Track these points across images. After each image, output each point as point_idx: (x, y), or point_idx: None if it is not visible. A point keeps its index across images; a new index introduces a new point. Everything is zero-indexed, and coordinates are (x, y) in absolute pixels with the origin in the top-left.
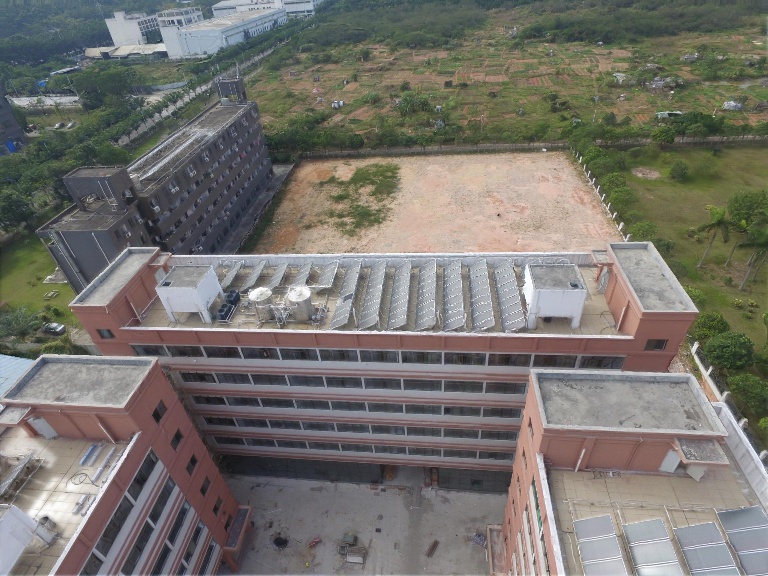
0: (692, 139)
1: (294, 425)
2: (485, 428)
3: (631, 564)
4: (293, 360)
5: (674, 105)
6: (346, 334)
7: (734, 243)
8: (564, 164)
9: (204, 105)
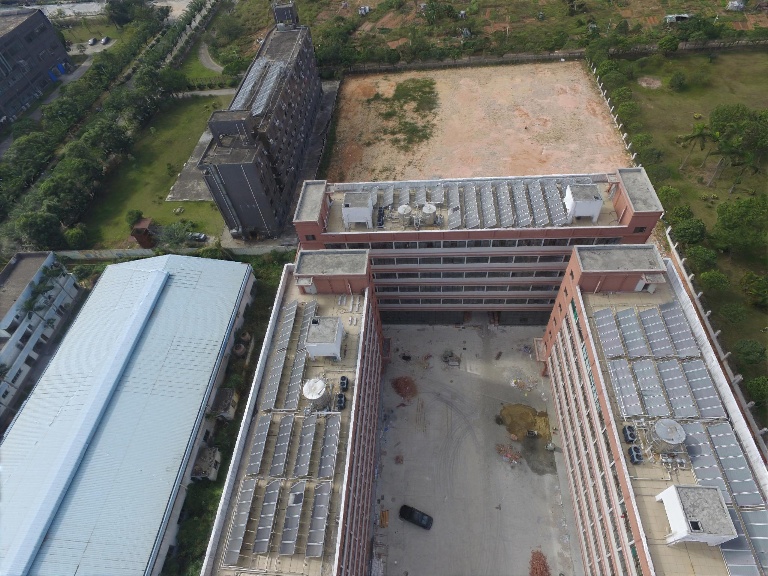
0: (693, 46)
1: (415, 289)
2: (535, 284)
3: (618, 326)
4: (425, 248)
5: (683, 5)
6: (462, 231)
7: (711, 147)
8: (580, 75)
9: (228, 12)
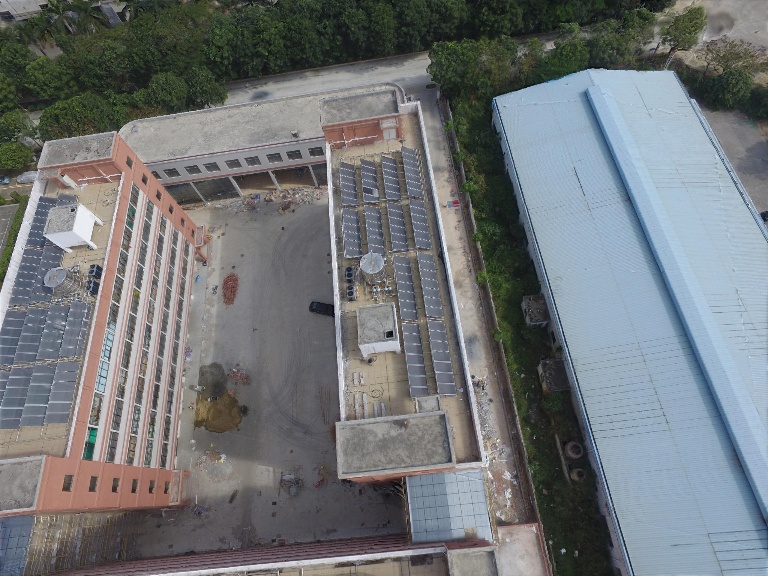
0: None
1: None
2: None
3: None
4: None
5: None
6: (198, 570)
7: None
8: None
9: None
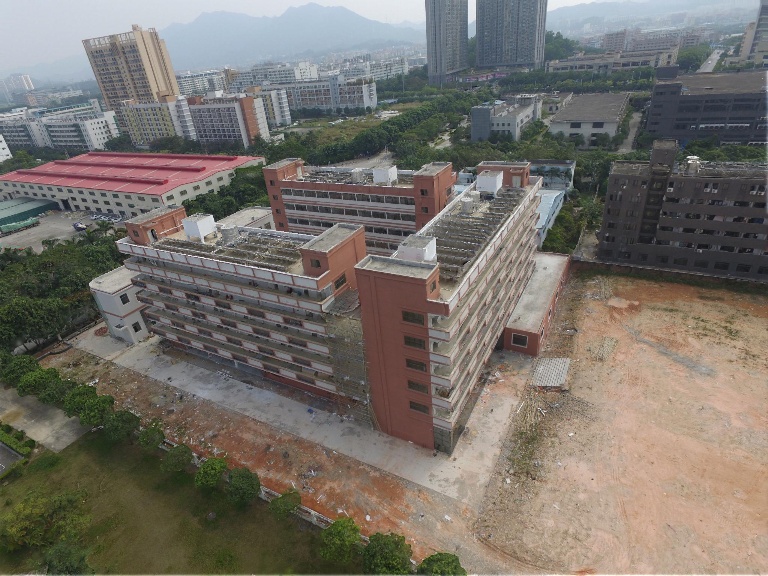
0: None
1: None
2: None
3: None
4: None
5: None
6: None
7: None
8: None
9: None
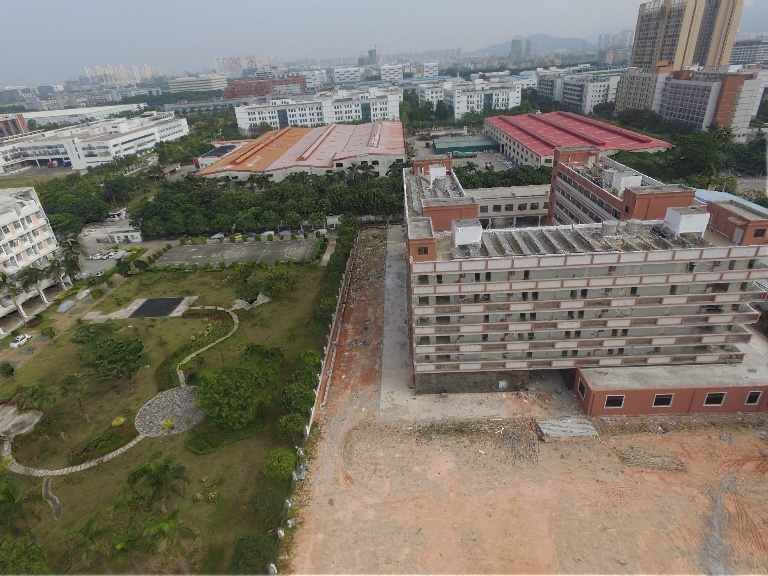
0: None
1: None
2: None
3: None
4: None
5: None
6: None
7: None
8: None
9: None
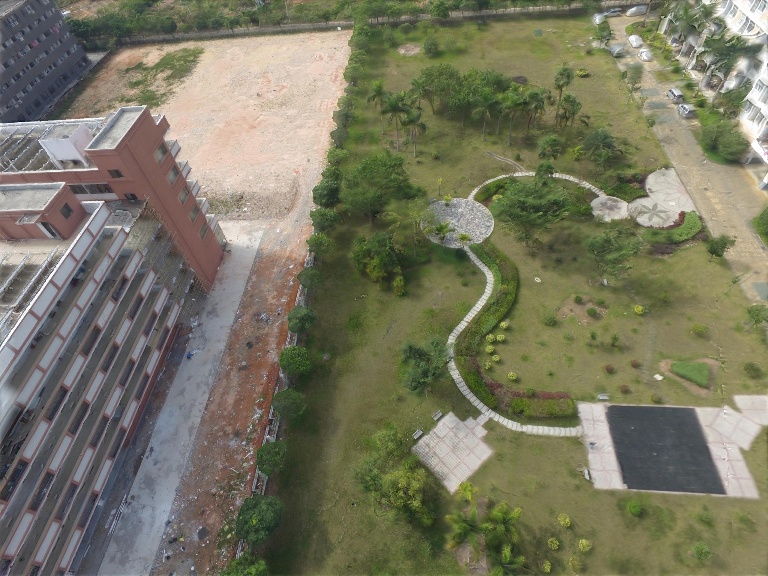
0: (468, 13)
1: None
2: None
3: None
4: None
5: None
6: None
7: (426, 112)
8: (346, 43)
9: None
